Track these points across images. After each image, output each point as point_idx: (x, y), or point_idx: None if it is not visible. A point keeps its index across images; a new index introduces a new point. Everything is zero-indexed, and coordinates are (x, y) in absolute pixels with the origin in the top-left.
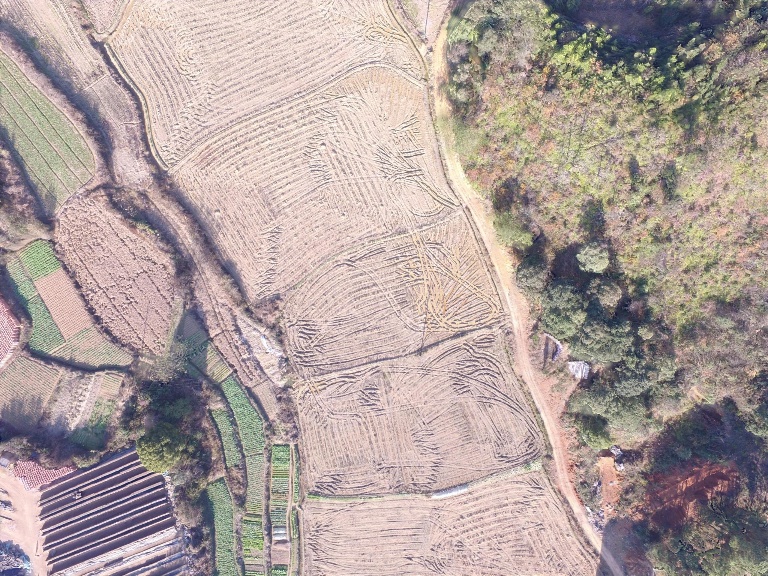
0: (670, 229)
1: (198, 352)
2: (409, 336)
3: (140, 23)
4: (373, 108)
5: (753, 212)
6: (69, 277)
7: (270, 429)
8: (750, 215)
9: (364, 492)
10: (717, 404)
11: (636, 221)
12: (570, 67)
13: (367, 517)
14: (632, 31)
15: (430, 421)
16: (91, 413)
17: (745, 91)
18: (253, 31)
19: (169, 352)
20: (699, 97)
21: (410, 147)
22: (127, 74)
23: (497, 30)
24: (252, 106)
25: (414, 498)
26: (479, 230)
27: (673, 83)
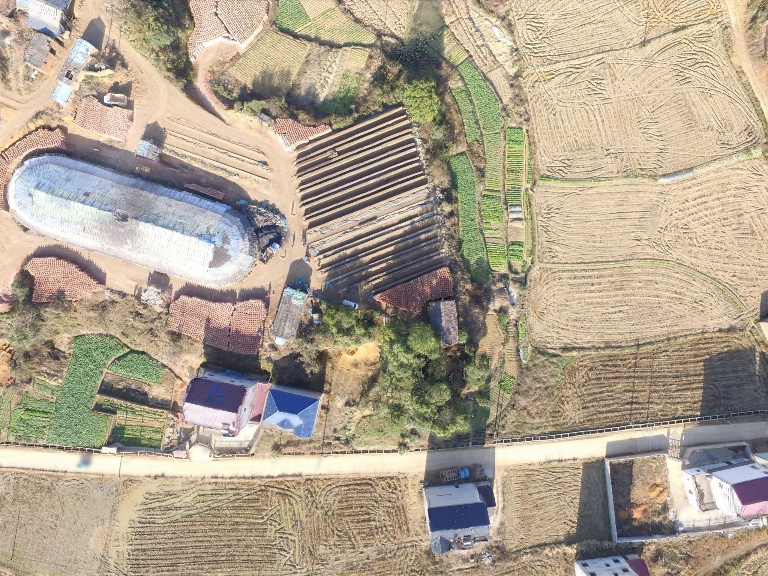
0: None
1: (435, 36)
2: (632, 30)
3: None
4: None
5: None
6: None
7: (505, 111)
8: None
9: (593, 176)
10: None
11: None
12: None
13: (596, 200)
14: None
15: (654, 110)
16: (339, 85)
17: None
18: None
19: (409, 34)
20: None
21: None
22: None
23: None
24: None
25: (641, 183)
26: None
27: None
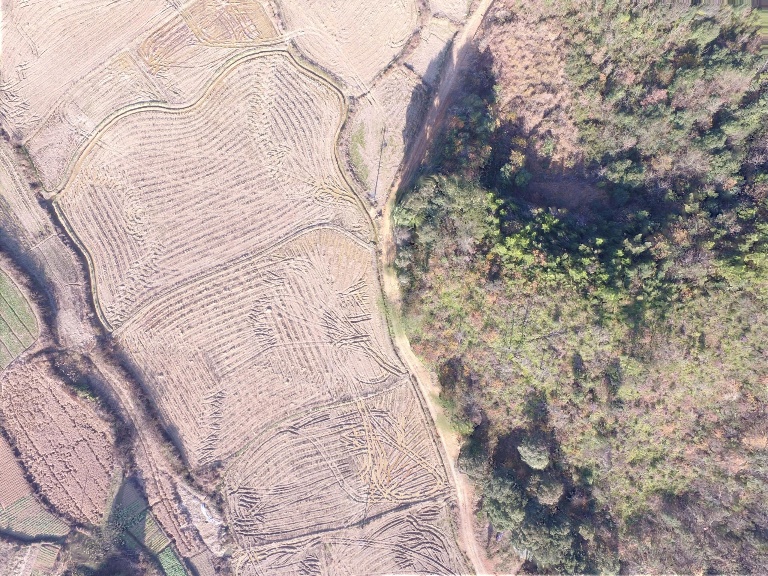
0: (615, 424)
1: (136, 521)
2: (352, 507)
3: (89, 181)
4: (320, 271)
5: (701, 410)
6: (9, 444)
7: None
8: (698, 413)
9: None
10: None
11: (579, 417)
12: (513, 257)
13: None
14: (582, 209)
15: None
16: None
17: (693, 289)
18: (201, 191)
19: (107, 522)
20: (644, 296)
21: (357, 312)
22: (74, 233)
23: (437, 222)
24: (198, 268)
25: None
26: (425, 400)
27: (617, 283)
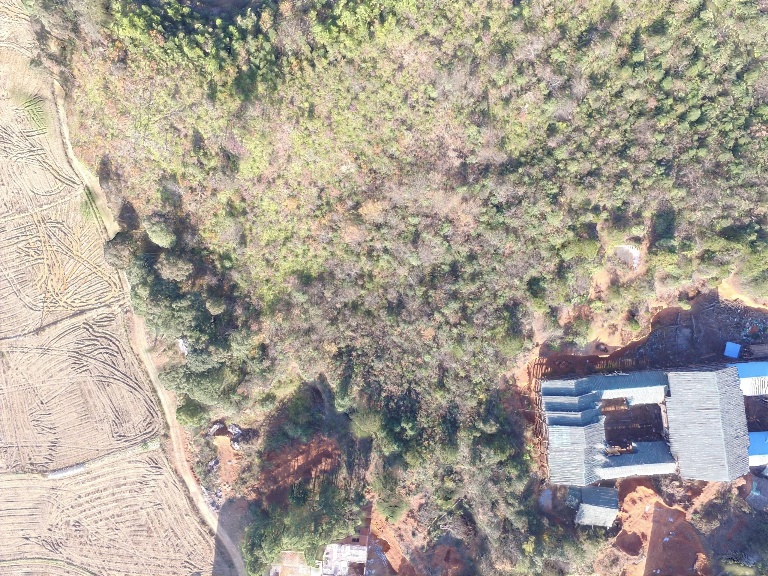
0: (241, 202)
1: None
2: (28, 315)
3: None
4: None
5: (321, 184)
6: None
7: None
8: (319, 187)
9: None
10: (316, 381)
11: (203, 195)
12: (135, 40)
13: None
14: (226, 4)
15: (48, 401)
16: None
17: (302, 61)
18: None
19: None
20: (252, 67)
21: (33, 126)
22: None
23: (53, 4)
24: None
25: (32, 478)
26: (98, 208)
27: (220, 53)
